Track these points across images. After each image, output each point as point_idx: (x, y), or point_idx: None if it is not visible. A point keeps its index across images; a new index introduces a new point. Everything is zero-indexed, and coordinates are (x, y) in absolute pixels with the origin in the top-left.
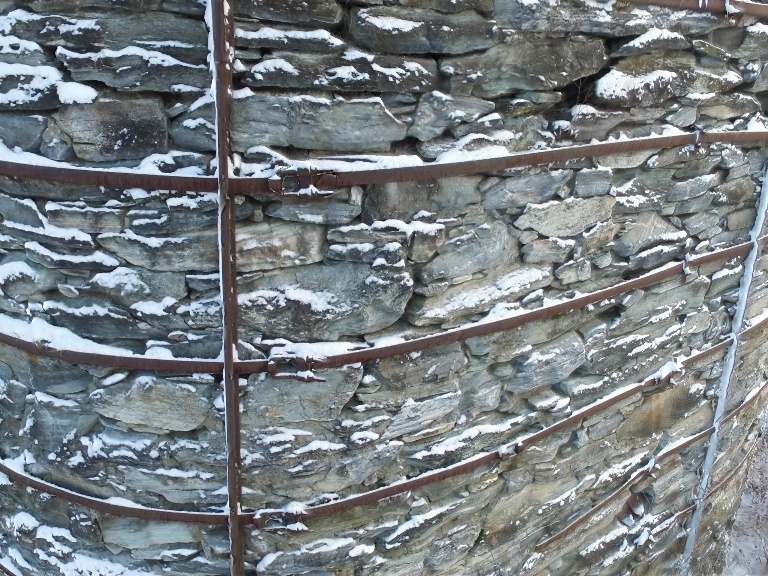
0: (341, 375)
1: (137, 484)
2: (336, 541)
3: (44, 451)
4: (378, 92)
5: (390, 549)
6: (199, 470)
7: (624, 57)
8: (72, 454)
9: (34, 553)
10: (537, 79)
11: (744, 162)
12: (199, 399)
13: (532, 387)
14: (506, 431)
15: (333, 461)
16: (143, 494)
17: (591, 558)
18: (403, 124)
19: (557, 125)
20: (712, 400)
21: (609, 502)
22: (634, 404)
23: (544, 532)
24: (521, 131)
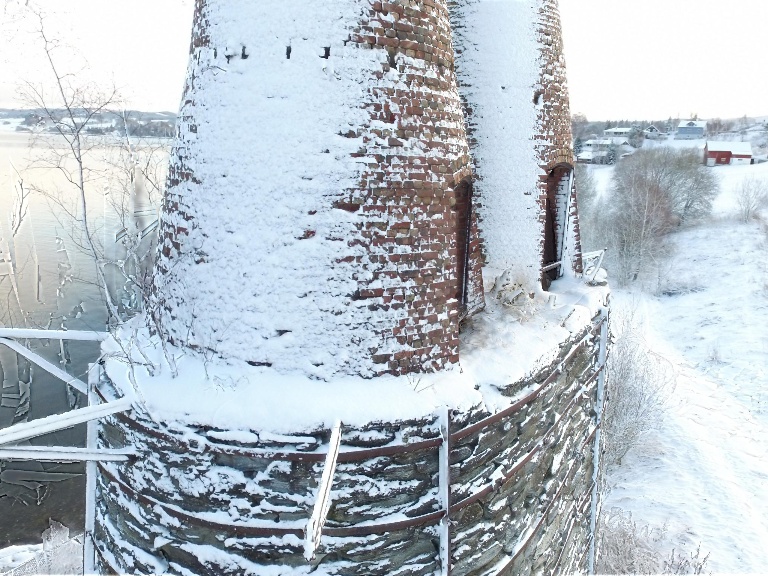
0: None
1: None
2: None
3: None
4: (496, 538)
5: None
6: None
7: None
8: None
9: None
10: (538, 487)
11: (588, 447)
12: None
13: None
14: None
15: None
16: None
17: None
18: None
19: (543, 499)
20: None
21: None
22: None
23: None
24: (533, 513)
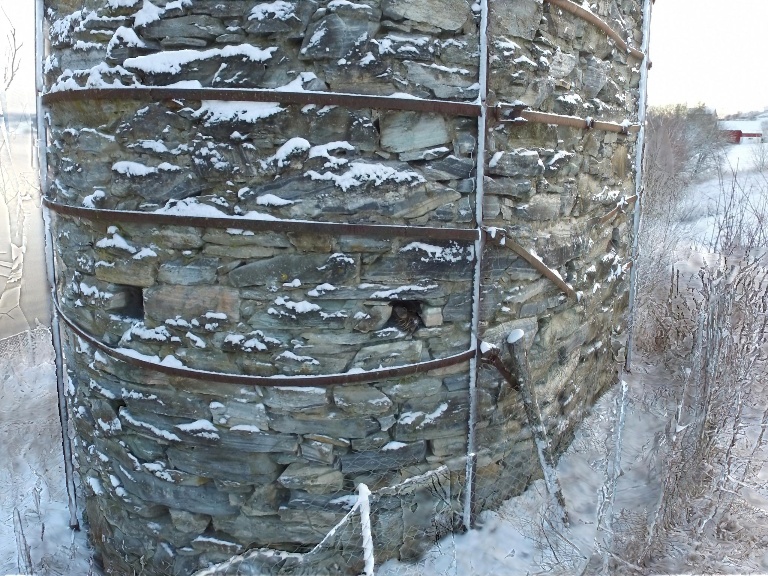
0: (536, 6)
1: (417, 78)
2: (530, 151)
3: (332, 60)
4: None
5: (553, 171)
6: (459, 68)
7: None
8: (363, 55)
9: (305, 176)
10: None
11: None
12: (464, 1)
13: (590, 86)
14: (586, 110)
15: (530, 78)
16: (420, 88)
17: (605, 268)
18: None
19: None
20: (632, 177)
21: (608, 226)
22: (615, 144)
23: (593, 223)
24: None
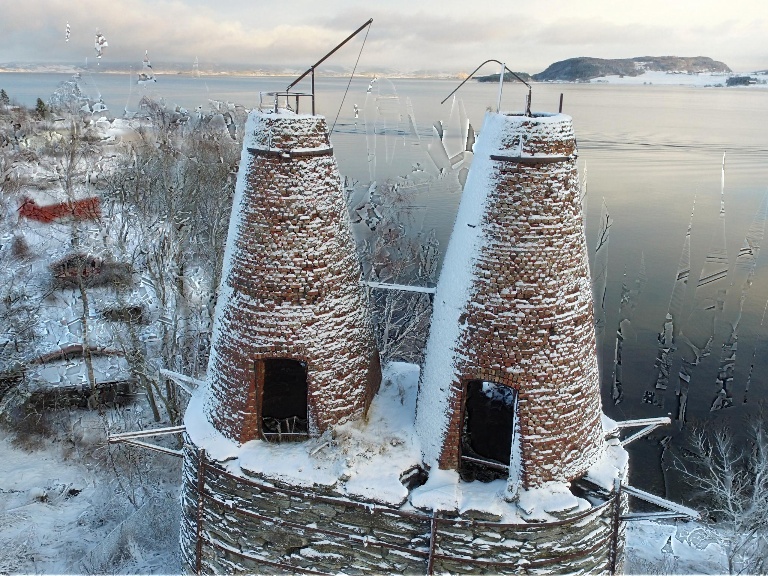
0: None
1: None
2: None
3: None
4: None
5: None
6: None
7: (315, 545)
8: None
9: None
10: None
11: None
12: None
13: None
14: None
15: None
16: None
17: None
18: (234, 541)
19: None
20: None
21: None
22: None
23: None
24: None
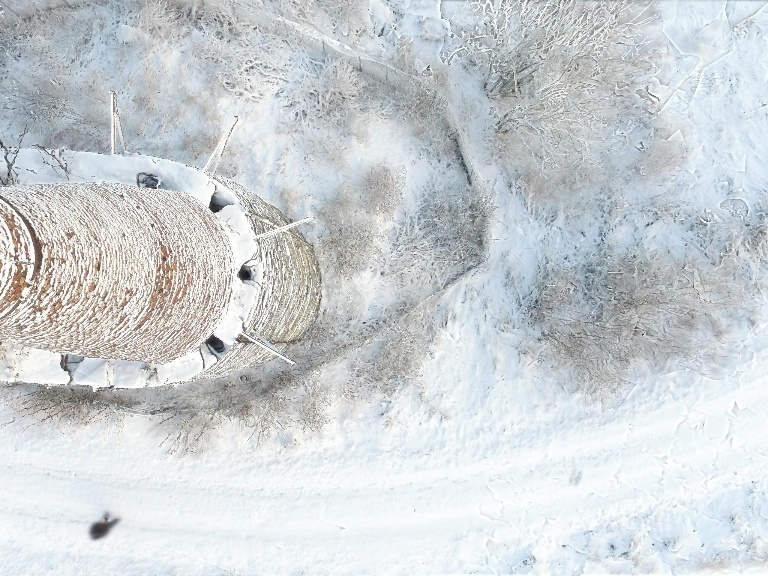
0: None
1: None
2: None
3: None
4: None
5: None
6: None
7: None
8: None
9: None
10: None
11: None
12: None
13: None
14: None
15: None
16: None
17: None
18: None
19: None
20: None
21: None
22: None
23: None
24: None
